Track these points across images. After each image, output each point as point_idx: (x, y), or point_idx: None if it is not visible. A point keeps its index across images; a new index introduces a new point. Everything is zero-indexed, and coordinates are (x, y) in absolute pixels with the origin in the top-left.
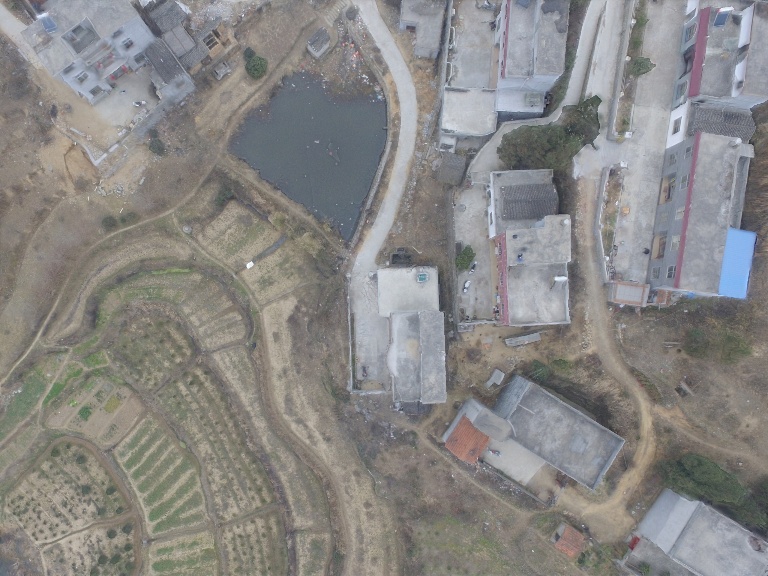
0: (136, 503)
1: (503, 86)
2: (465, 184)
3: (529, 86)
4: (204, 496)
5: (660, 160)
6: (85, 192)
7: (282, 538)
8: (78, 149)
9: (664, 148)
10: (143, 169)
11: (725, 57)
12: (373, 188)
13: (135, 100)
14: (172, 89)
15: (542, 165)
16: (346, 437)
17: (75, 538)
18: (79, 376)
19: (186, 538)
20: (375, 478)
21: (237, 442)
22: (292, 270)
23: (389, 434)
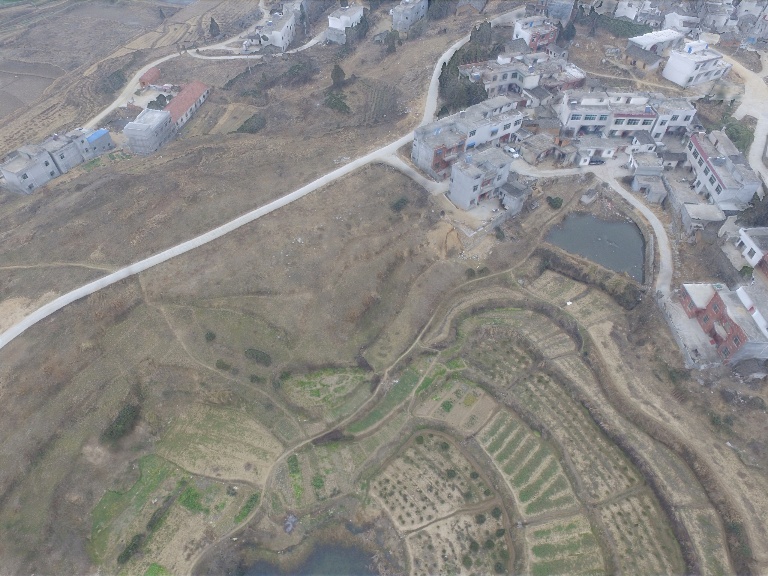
0: (504, 484)
1: (721, 199)
2: (724, 238)
3: (738, 198)
4: (568, 480)
5: None
6: (452, 258)
7: (663, 519)
8: (455, 231)
9: None
10: (490, 247)
11: None
12: (651, 254)
13: (491, 210)
14: (516, 204)
15: None
16: (693, 416)
17: (441, 524)
18: (443, 375)
19: (561, 521)
20: (738, 448)
21: (590, 428)
22: (602, 306)
23: (738, 400)
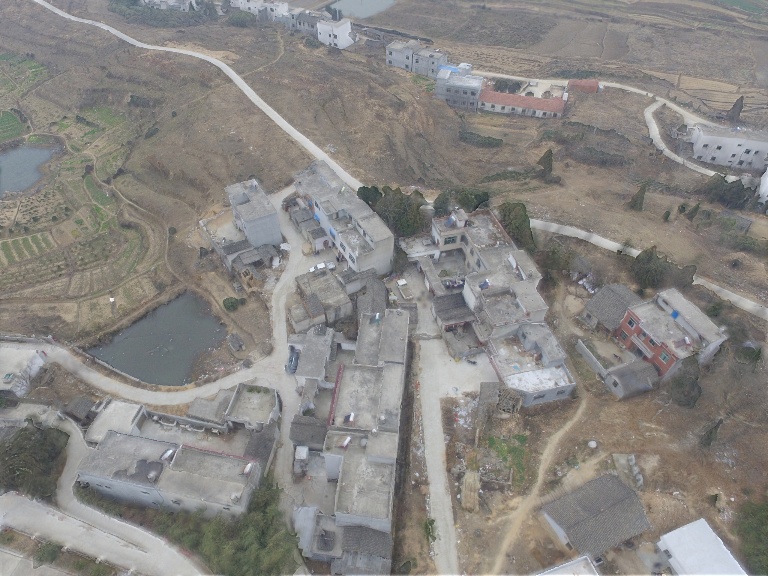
0: (8, 238)
1: None
2: (53, 407)
3: None
4: None
5: None
6: (197, 223)
7: None
8: None
9: None
10: (197, 248)
11: None
12: None
13: (228, 239)
14: None
15: None
16: None
17: (13, 214)
18: (101, 220)
19: None
20: None
21: (4, 286)
22: None
23: None
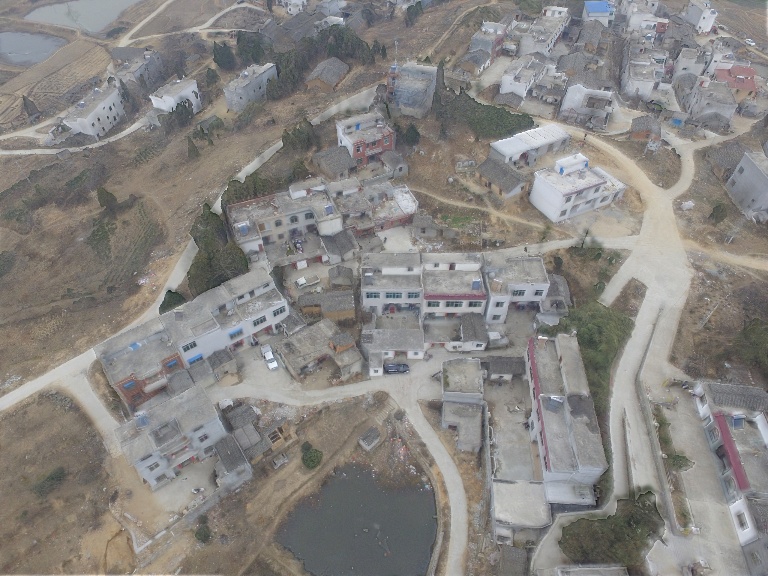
0: None
1: (550, 479)
2: None
3: (576, 479)
4: None
5: (741, 559)
6: None
7: None
8: (124, 535)
9: (739, 545)
10: (183, 557)
11: (759, 457)
12: None
13: (194, 487)
14: (232, 477)
15: (614, 563)
16: None
17: None
18: None
19: None
20: None
21: None
22: None
23: None
